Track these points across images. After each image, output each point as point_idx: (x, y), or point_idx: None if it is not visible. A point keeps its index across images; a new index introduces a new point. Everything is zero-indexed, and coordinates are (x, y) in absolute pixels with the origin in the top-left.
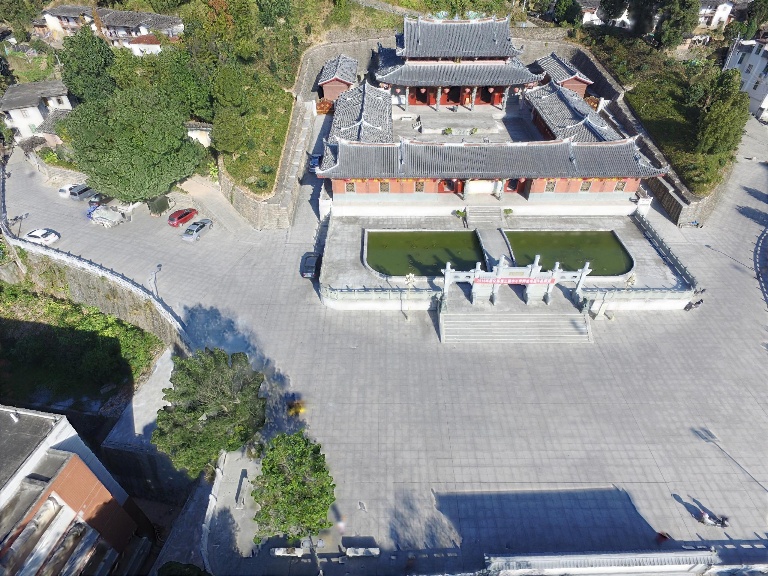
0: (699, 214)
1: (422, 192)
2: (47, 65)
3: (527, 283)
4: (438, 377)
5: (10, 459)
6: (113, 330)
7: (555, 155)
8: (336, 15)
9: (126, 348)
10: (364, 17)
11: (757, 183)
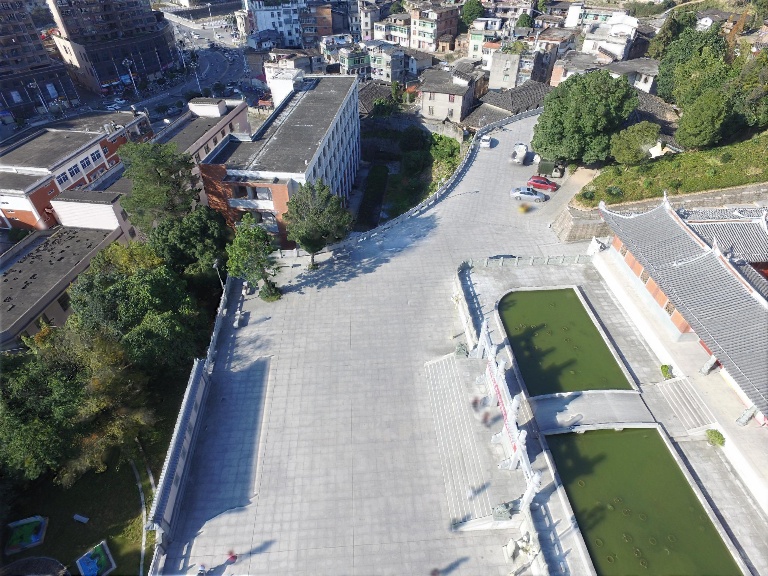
0: None
1: (670, 316)
2: None
3: None
4: (380, 360)
5: (285, 170)
6: None
7: None
8: None
9: None
10: None
11: None
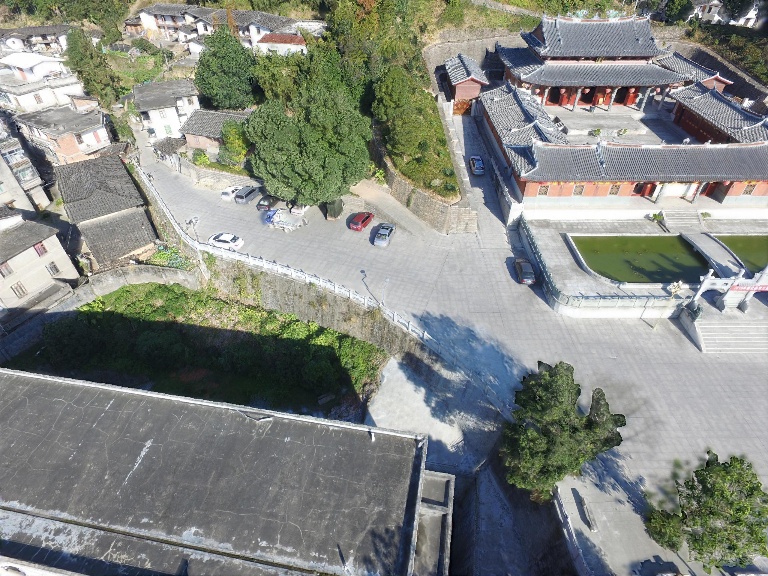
0: None
1: (616, 195)
2: (154, 64)
3: None
4: (720, 389)
5: (393, 482)
6: (326, 338)
7: (758, 157)
8: (450, 14)
9: (346, 357)
10: (477, 16)
11: None
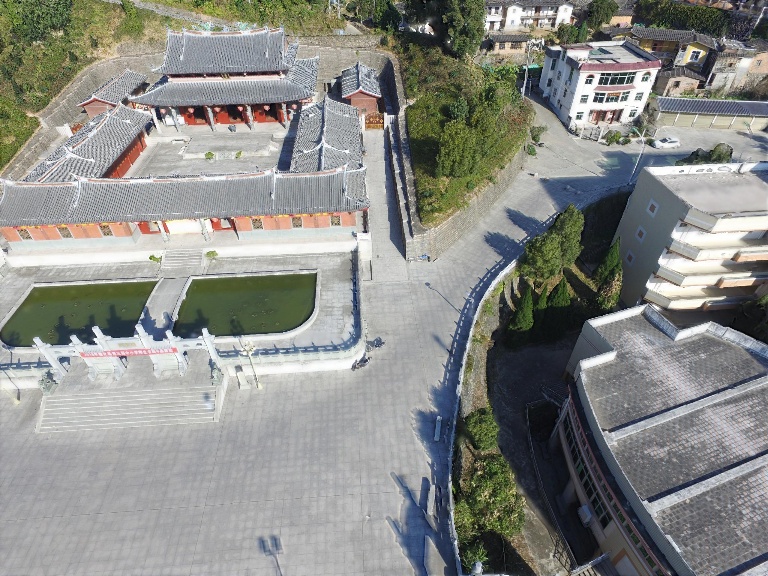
0: (428, 247)
1: (112, 236)
2: None
3: (146, 354)
4: None
5: None
6: None
7: (255, 189)
8: (127, 26)
9: None
10: (159, 27)
11: (524, 203)
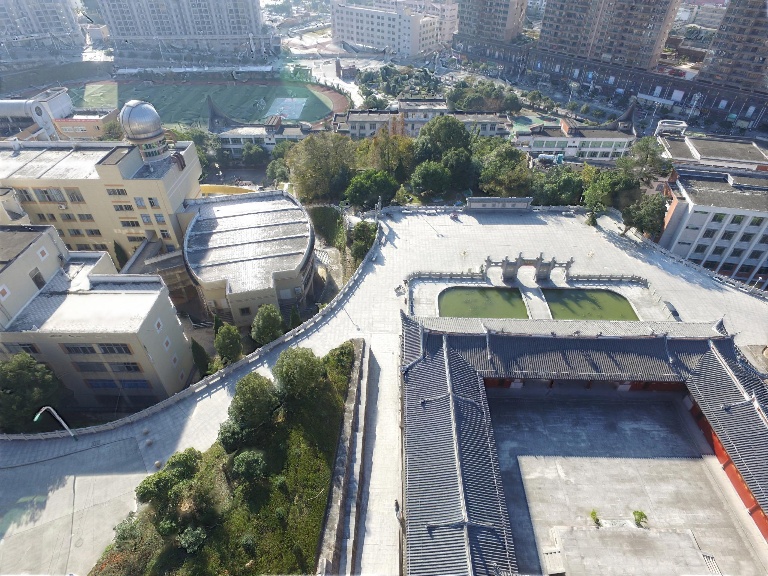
0: None
1: None
2: None
3: None
4: (556, 255)
5: None
6: None
7: None
8: None
9: None
10: None
11: (221, 418)
